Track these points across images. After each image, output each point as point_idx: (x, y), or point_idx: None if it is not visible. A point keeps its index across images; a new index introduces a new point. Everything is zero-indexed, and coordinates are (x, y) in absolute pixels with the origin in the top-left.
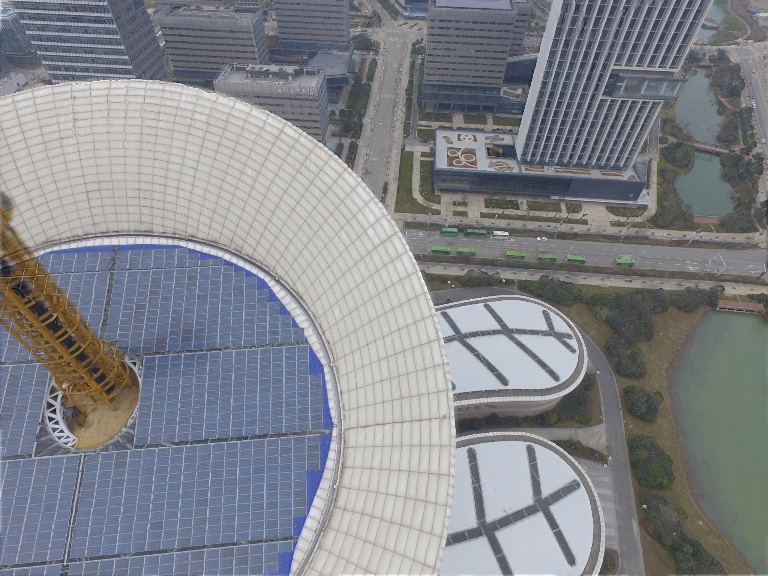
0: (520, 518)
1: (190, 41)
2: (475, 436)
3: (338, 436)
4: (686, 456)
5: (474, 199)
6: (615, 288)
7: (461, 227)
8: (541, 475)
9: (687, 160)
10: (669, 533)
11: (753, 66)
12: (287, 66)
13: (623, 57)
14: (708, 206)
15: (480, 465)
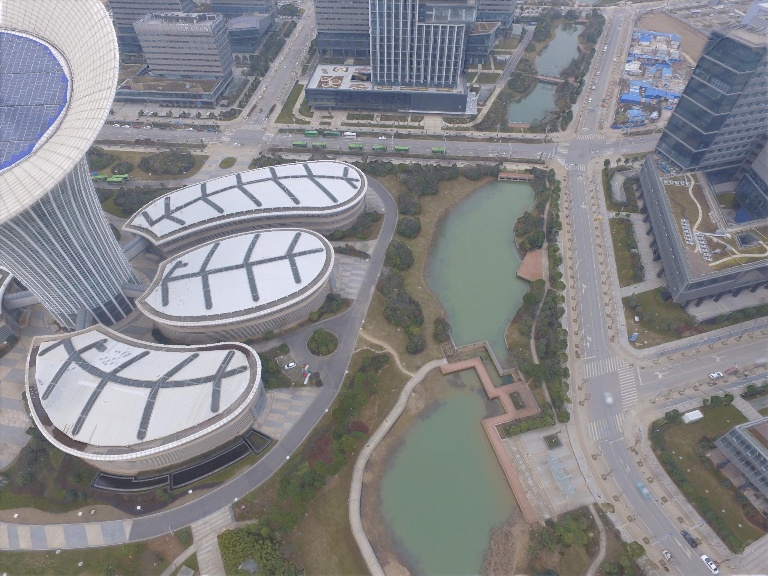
0: (272, 261)
1: (129, 1)
2: (266, 229)
3: (68, 106)
4: (430, 257)
5: (340, 114)
6: (424, 166)
7: (320, 130)
8: (298, 244)
9: (525, 87)
10: (391, 289)
11: (622, 21)
12: (194, 13)
13: None
14: (532, 119)
15: (259, 240)
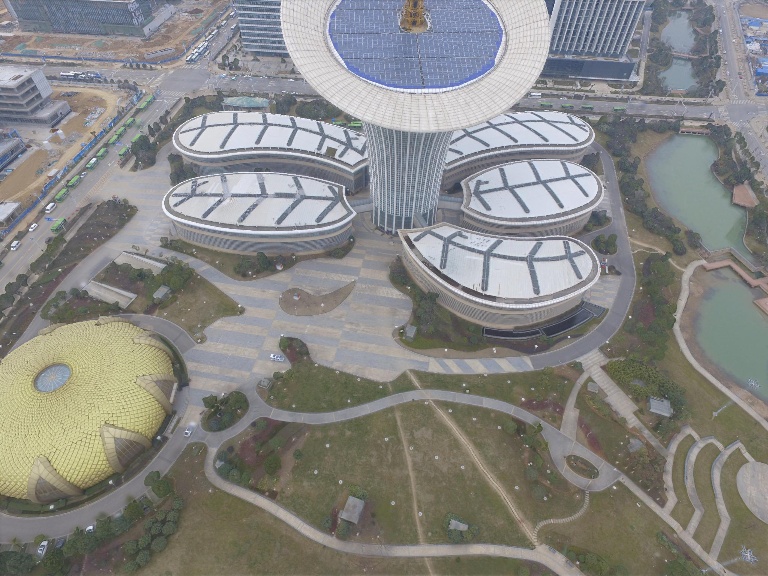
0: (559, 180)
1: None
2: (531, 160)
3: (505, 33)
4: (653, 189)
5: None
6: None
7: None
8: (569, 169)
9: (667, 61)
10: None
11: (724, 9)
12: None
13: None
14: None
15: (536, 166)
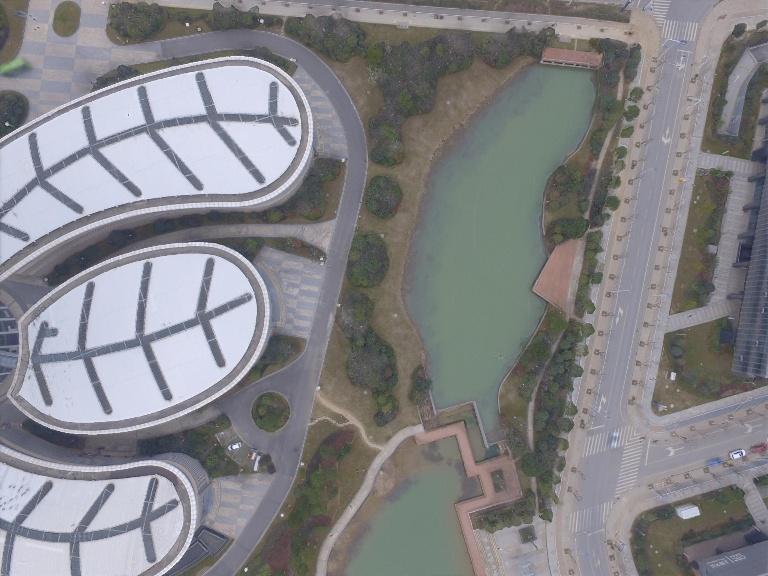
0: (177, 331)
1: None
2: (158, 248)
3: None
4: (413, 252)
5: None
6: (416, 30)
7: None
8: (211, 290)
9: None
10: (355, 327)
11: None
12: None
13: None
14: None
15: (152, 280)
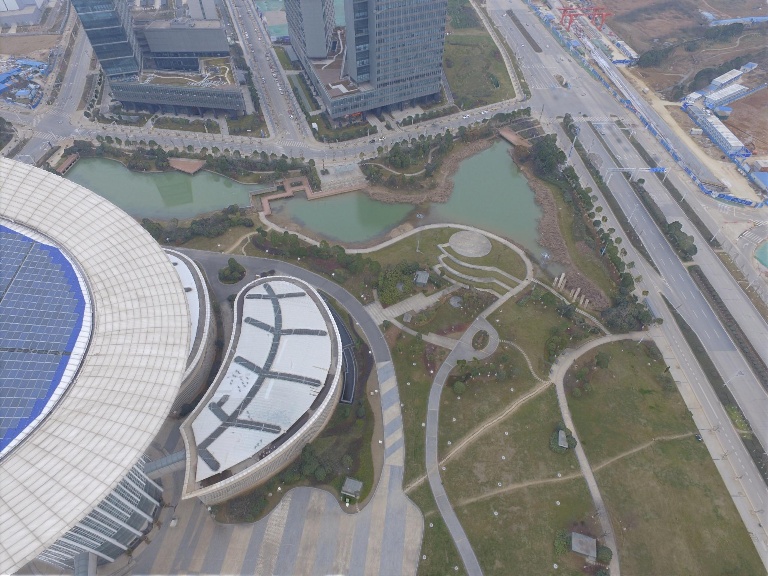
0: None
1: None
2: None
3: None
4: (151, 218)
5: None
6: None
7: None
8: None
9: None
10: None
11: None
12: None
13: None
14: None
15: None
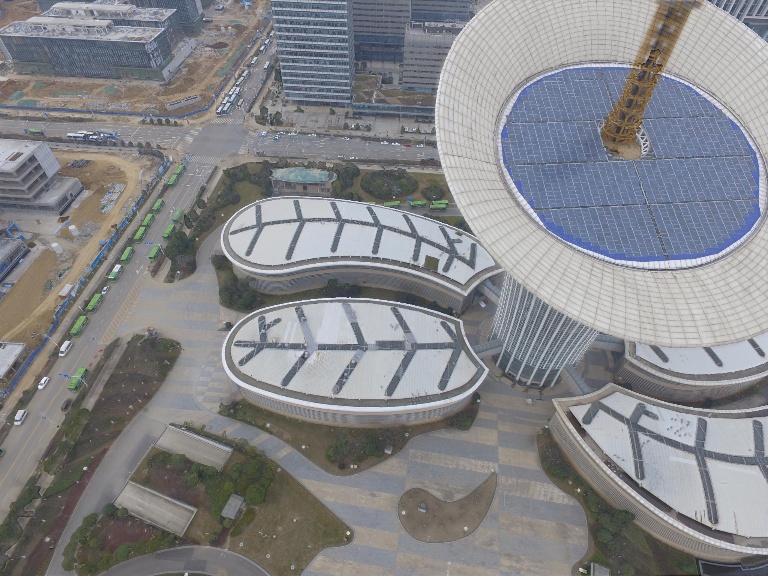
0: None
1: (354, 7)
2: None
3: (761, 157)
4: None
5: None
6: None
7: None
8: None
9: None
10: None
11: None
12: None
13: (755, 8)
14: None
15: None
